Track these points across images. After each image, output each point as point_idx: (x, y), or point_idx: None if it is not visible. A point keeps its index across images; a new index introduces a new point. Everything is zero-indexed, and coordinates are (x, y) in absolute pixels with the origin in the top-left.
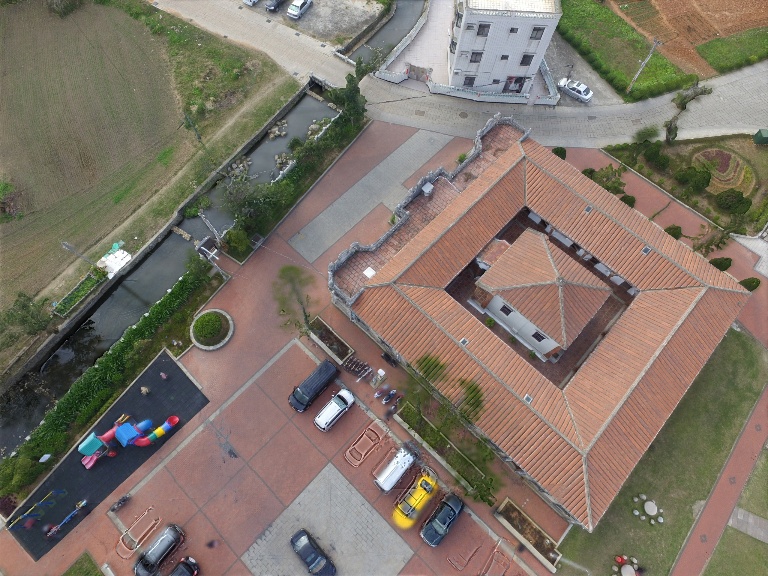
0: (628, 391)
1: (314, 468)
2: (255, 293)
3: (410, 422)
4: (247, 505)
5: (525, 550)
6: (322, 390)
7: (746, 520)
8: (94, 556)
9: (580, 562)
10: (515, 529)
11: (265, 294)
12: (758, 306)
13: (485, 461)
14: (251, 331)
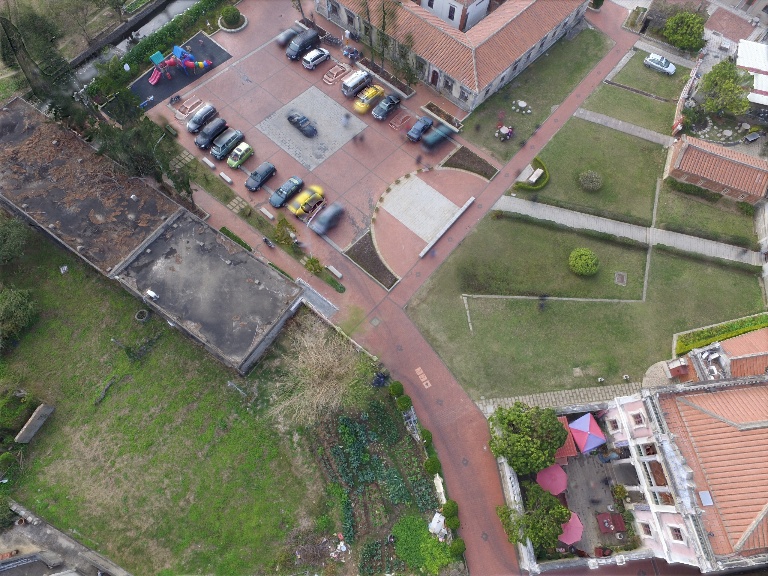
0: (504, 24)
1: (303, 88)
2: (262, 6)
3: (367, 66)
4: (259, 103)
5: (440, 125)
6: (308, 46)
7: (585, 113)
8: (160, 124)
9: (475, 130)
10: (434, 113)
11: (269, 7)
12: (607, 17)
13: (416, 86)
14: (260, 24)
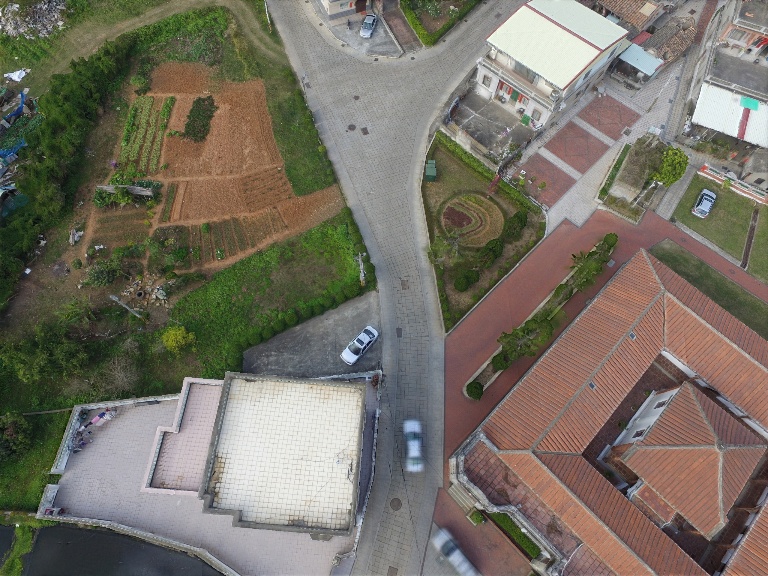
0: None
1: None
2: None
3: None
4: None
5: None
6: None
7: None
8: None
9: None
10: None
11: None
12: (618, 236)
13: None
14: None
